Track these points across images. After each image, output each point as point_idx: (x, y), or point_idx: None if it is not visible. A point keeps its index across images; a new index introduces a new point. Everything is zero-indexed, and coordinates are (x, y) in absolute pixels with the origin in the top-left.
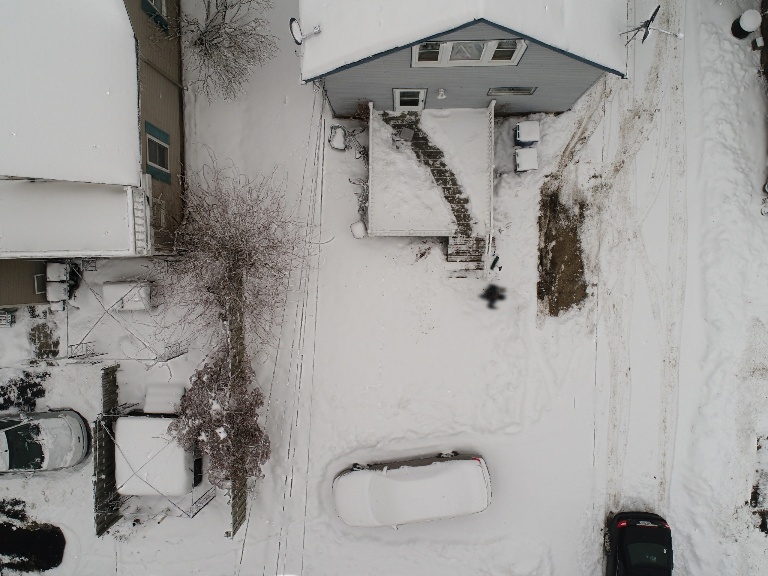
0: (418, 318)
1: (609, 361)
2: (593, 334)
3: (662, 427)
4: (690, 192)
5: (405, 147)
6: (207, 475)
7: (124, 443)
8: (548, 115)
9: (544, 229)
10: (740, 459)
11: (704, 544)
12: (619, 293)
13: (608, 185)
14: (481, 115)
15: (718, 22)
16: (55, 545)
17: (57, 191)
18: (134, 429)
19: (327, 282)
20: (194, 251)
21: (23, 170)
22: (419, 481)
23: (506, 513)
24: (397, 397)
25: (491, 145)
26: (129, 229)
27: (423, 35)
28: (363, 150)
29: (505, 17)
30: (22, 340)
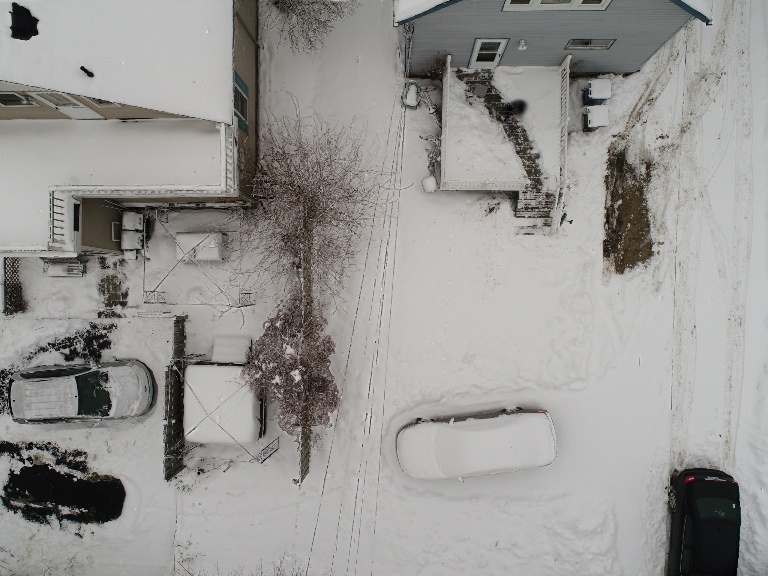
0: (485, 274)
1: (675, 319)
2: (659, 291)
3: (727, 385)
4: (756, 153)
5: (478, 103)
6: (271, 427)
7: (194, 390)
8: (617, 76)
9: (611, 188)
10: None
11: None
12: (685, 251)
13: (675, 145)
14: (554, 73)
15: None
16: (115, 497)
17: (148, 130)
18: (204, 376)
19: None
20: (273, 197)
21: (129, 98)
22: (487, 431)
23: (569, 470)
24: (462, 352)
25: (566, 99)
26: (221, 165)
27: None
28: (435, 107)
29: None
30: (92, 290)
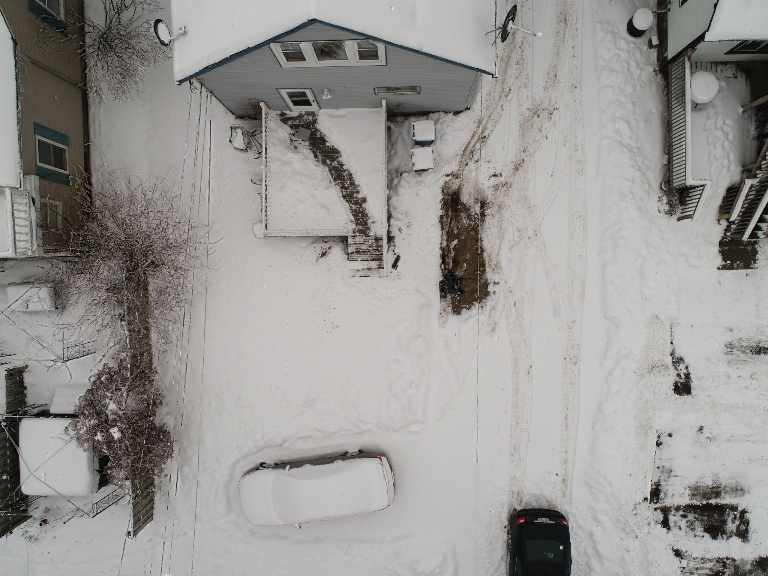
0: (322, 317)
1: (511, 359)
2: (495, 332)
3: (564, 424)
4: (589, 190)
5: (303, 147)
6: None
7: (27, 444)
8: (447, 114)
9: (446, 228)
10: (639, 456)
11: (606, 540)
12: (520, 291)
13: (508, 184)
14: (377, 115)
15: (614, 21)
16: None
17: None
18: (37, 430)
19: (232, 282)
20: (89, 252)
21: None
22: (318, 479)
23: (411, 511)
24: (303, 396)
25: None
26: (8, 230)
27: (268, 35)
28: None
29: (342, 17)
30: None
